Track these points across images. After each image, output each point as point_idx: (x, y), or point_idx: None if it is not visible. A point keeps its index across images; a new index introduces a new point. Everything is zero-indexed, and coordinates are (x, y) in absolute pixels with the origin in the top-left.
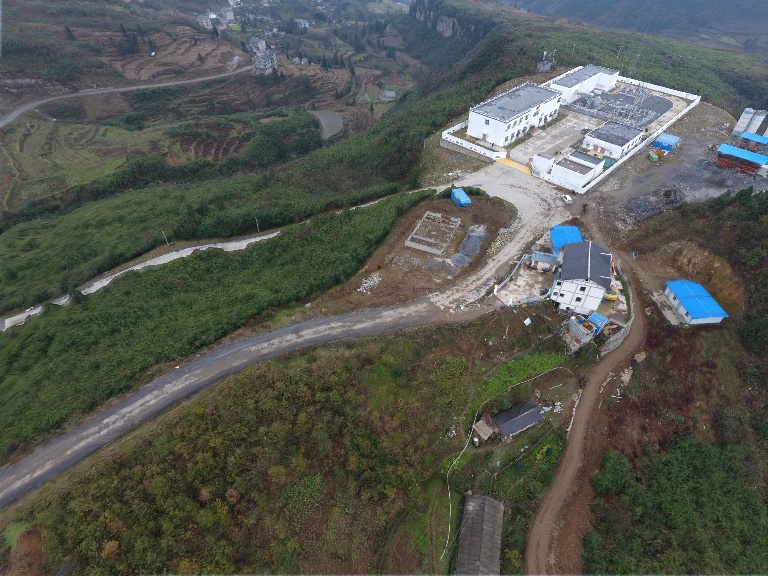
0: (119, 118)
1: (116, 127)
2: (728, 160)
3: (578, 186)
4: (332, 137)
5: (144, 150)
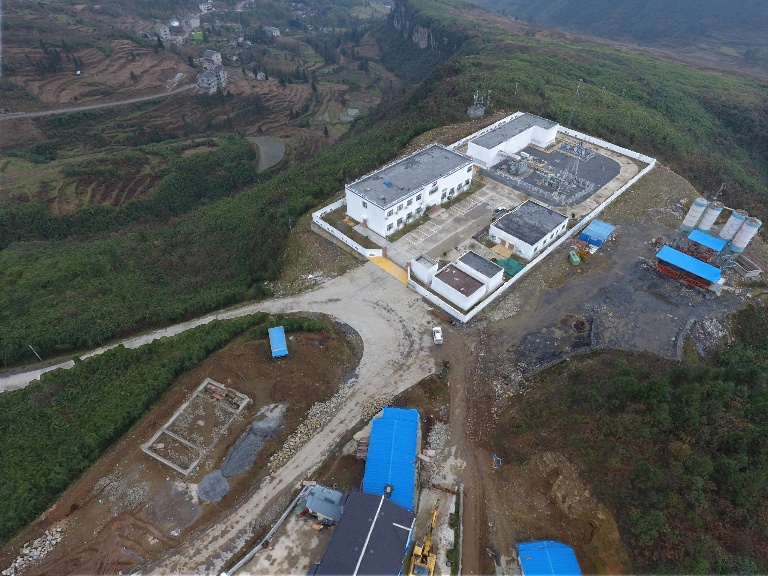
0: (27, 147)
1: (21, 159)
2: (671, 269)
3: (458, 312)
4: (268, 169)
5: (29, 194)
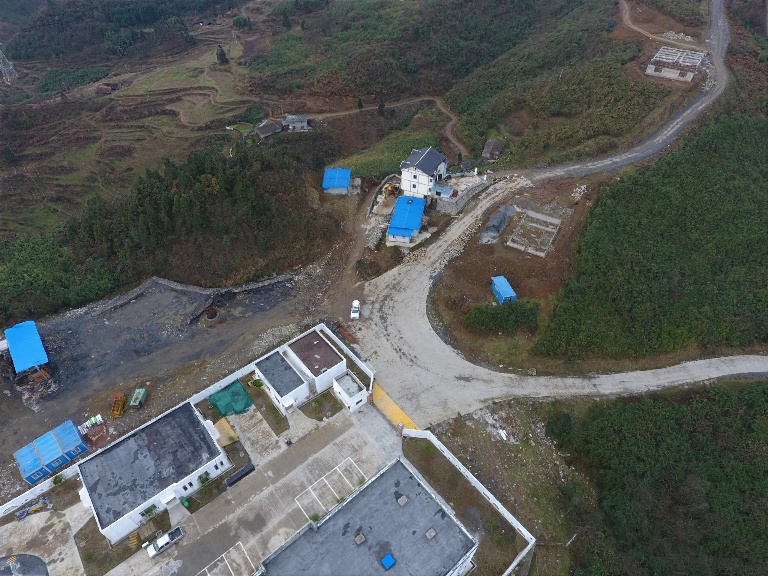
0: None
1: None
2: None
3: None
4: None
5: None
